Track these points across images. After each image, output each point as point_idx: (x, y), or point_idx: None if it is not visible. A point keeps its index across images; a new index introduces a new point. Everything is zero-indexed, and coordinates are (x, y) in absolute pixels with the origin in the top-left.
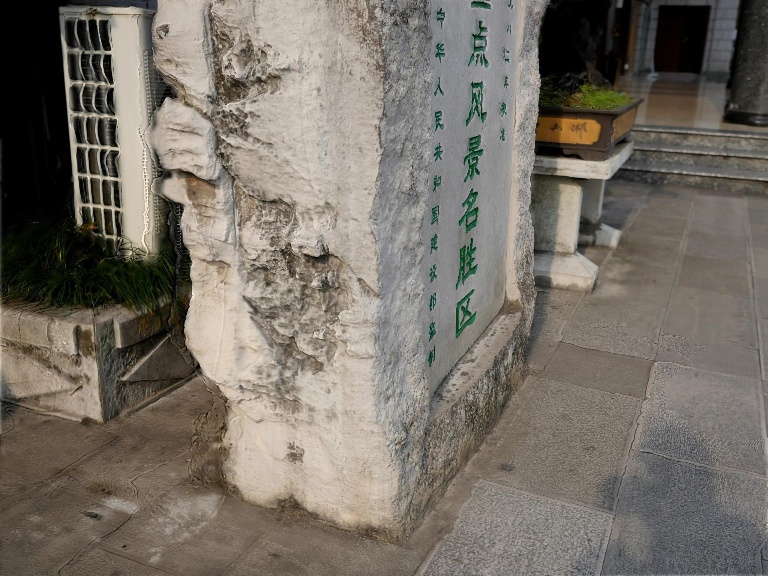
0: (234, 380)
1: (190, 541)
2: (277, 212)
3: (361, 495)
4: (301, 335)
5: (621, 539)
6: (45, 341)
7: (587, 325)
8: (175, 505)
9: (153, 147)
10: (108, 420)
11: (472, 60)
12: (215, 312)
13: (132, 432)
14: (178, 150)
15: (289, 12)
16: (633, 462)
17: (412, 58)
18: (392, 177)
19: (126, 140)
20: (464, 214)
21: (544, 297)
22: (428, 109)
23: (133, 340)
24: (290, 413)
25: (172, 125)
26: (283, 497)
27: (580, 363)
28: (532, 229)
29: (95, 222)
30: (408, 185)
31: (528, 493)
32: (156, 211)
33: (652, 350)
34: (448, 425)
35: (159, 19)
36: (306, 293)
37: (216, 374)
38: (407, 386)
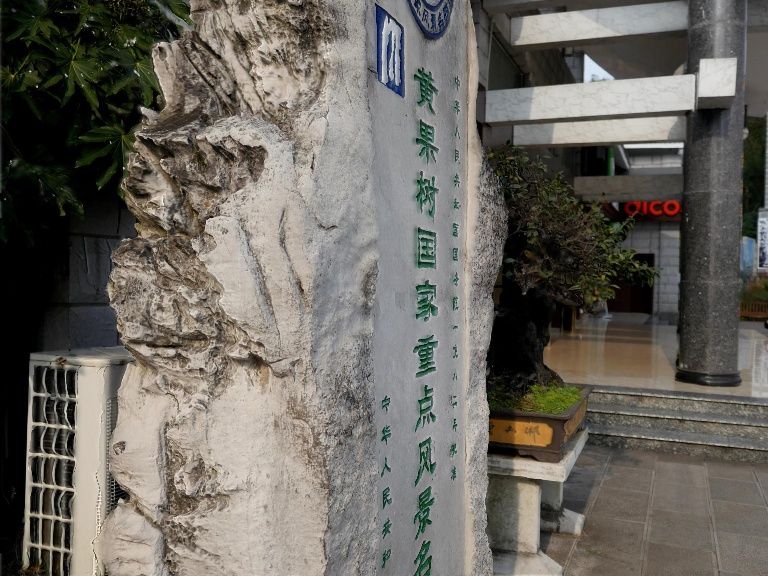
0: None
1: None
2: None
3: None
4: None
5: None
6: None
7: None
8: None
9: (101, 557)
10: None
11: (419, 423)
12: None
13: None
14: (125, 560)
15: (239, 436)
16: None
17: (357, 462)
18: None
19: (82, 483)
20: (417, 570)
21: None
22: (374, 499)
23: None
24: None
25: (121, 536)
26: None
27: None
28: (490, 552)
29: (42, 565)
30: None
31: None
32: None
33: None
34: None
35: (117, 436)
36: None
37: None
38: None
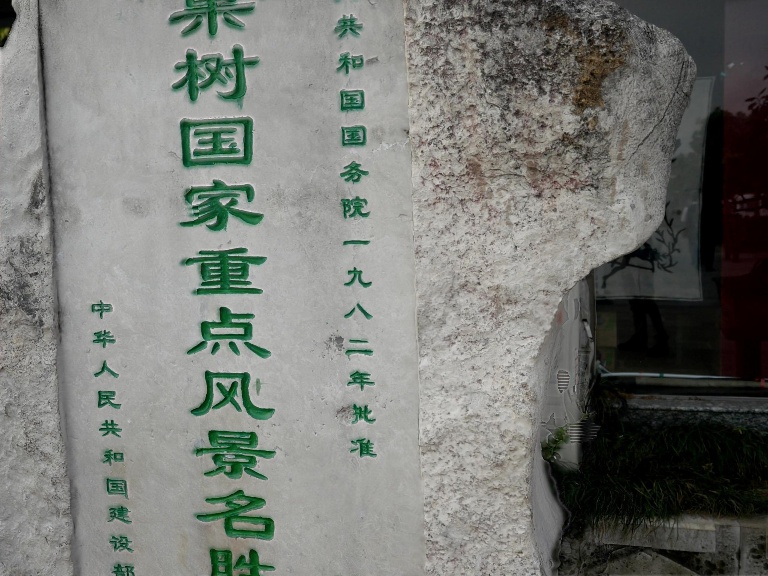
0: None
1: None
2: None
3: None
4: None
5: None
6: None
7: None
8: None
9: None
10: None
11: (205, 348)
12: None
13: None
14: None
15: None
16: None
17: (13, 343)
18: (4, 430)
19: None
20: (219, 513)
21: None
22: (52, 386)
23: None
24: None
25: None
26: None
27: None
28: None
29: None
30: (24, 442)
31: None
32: None
33: None
34: None
35: None
36: None
37: None
38: None
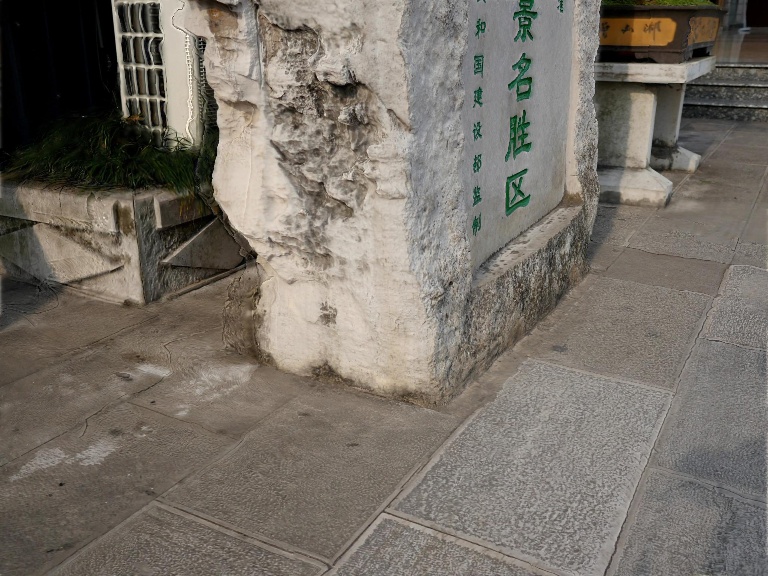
0: (262, 231)
1: (220, 401)
2: (303, 43)
3: (396, 356)
4: (330, 179)
5: (681, 413)
6: (85, 215)
7: (657, 234)
8: (206, 366)
9: None
10: (150, 301)
11: None
12: (242, 159)
13: (173, 312)
14: None
15: None
16: (699, 348)
17: None
18: None
19: (169, 24)
20: (514, 79)
21: (612, 211)
22: None
23: (174, 221)
24: (322, 269)
25: None
26: (317, 364)
27: (647, 265)
28: (596, 122)
29: (141, 113)
30: (443, 11)
31: (580, 371)
32: (200, 99)
33: (728, 255)
34: (493, 297)
35: None
36: (335, 134)
37: (244, 225)
38: (445, 242)
